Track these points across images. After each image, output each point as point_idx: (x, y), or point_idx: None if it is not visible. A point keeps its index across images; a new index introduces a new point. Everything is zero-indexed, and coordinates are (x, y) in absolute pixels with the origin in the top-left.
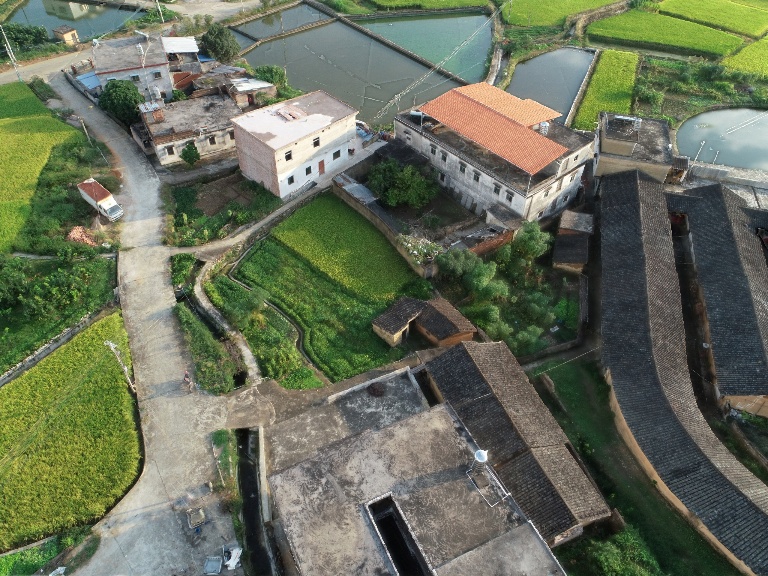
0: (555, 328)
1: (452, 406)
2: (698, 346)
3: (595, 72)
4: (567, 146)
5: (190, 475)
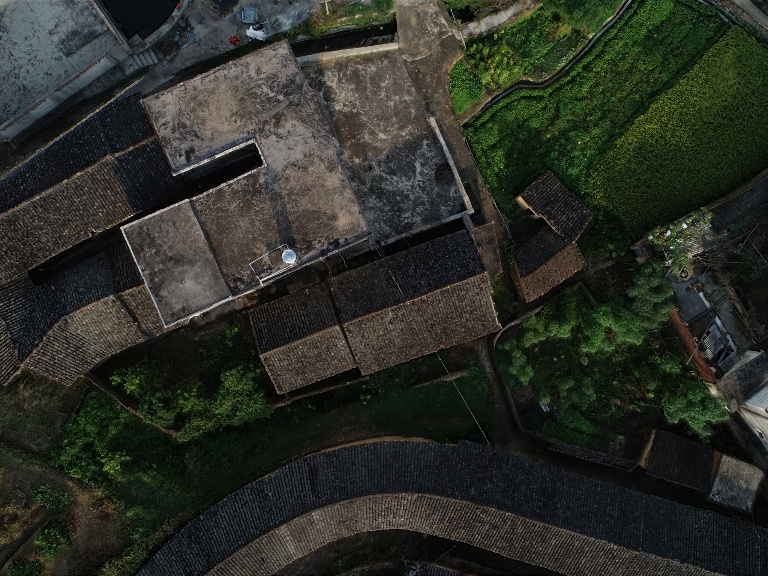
0: (546, 407)
1: (407, 254)
2: (513, 575)
3: None
4: None
5: None
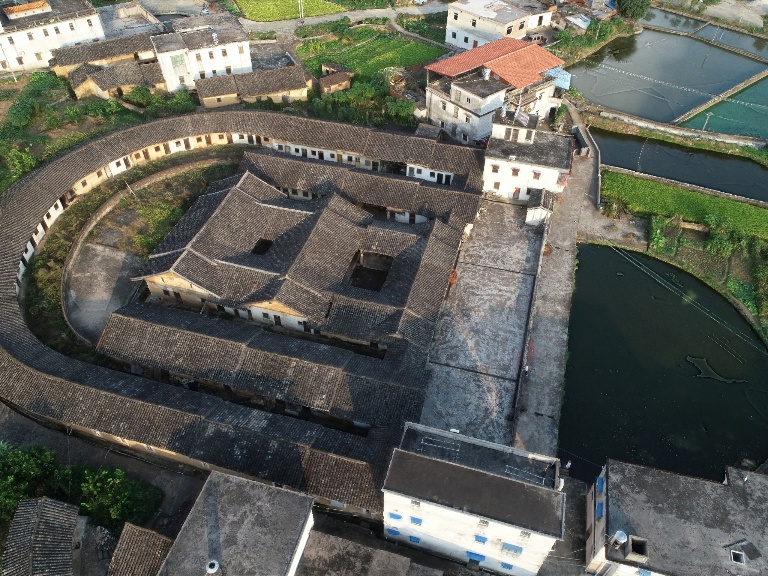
0: None
1: None
2: None
3: (760, 207)
4: (471, 87)
5: (257, 29)
